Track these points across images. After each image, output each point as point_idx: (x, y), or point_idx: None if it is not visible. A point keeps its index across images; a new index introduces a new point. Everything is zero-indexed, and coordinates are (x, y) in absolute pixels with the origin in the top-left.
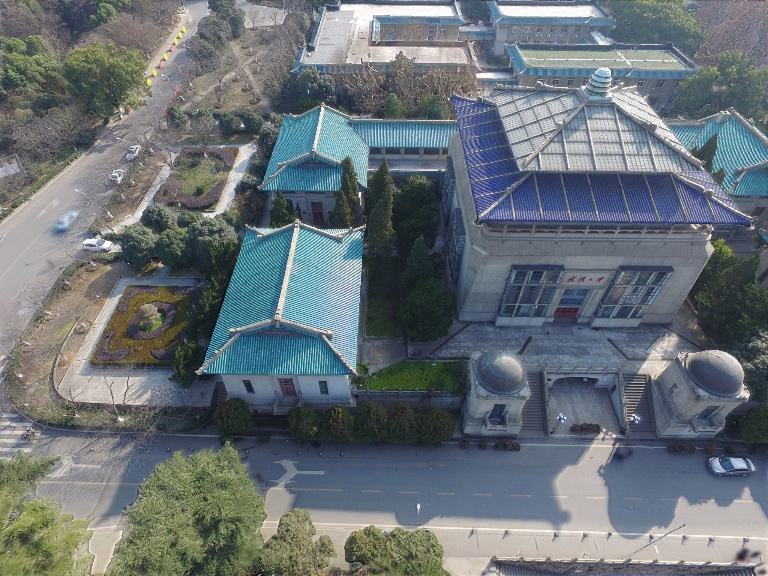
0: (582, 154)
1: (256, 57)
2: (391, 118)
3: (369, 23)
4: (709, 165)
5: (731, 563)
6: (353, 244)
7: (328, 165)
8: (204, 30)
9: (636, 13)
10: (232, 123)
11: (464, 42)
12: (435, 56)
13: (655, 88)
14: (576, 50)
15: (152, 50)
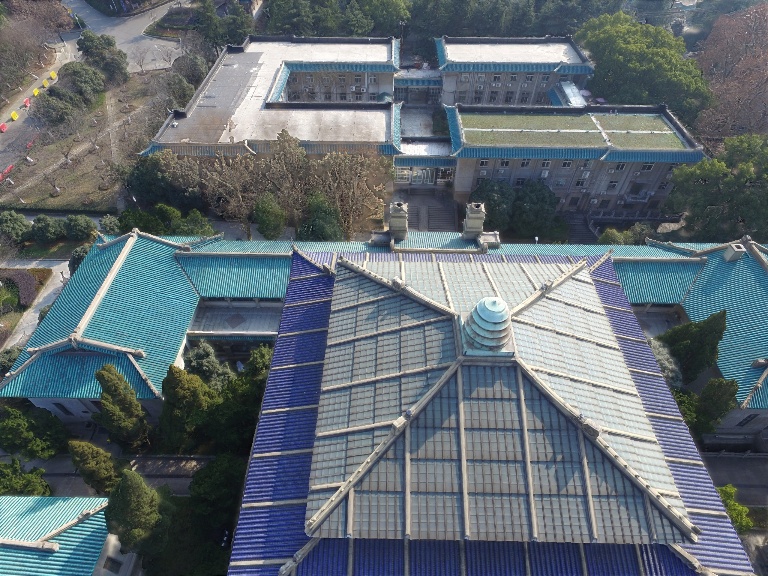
0: (441, 493)
1: (128, 117)
2: (262, 229)
3: (275, 72)
4: (712, 353)
5: None
6: (80, 548)
7: (104, 353)
8: (58, 83)
9: (619, 62)
10: (48, 231)
11: (387, 104)
12: (344, 126)
13: (641, 172)
14: (537, 114)
15: (3, 105)
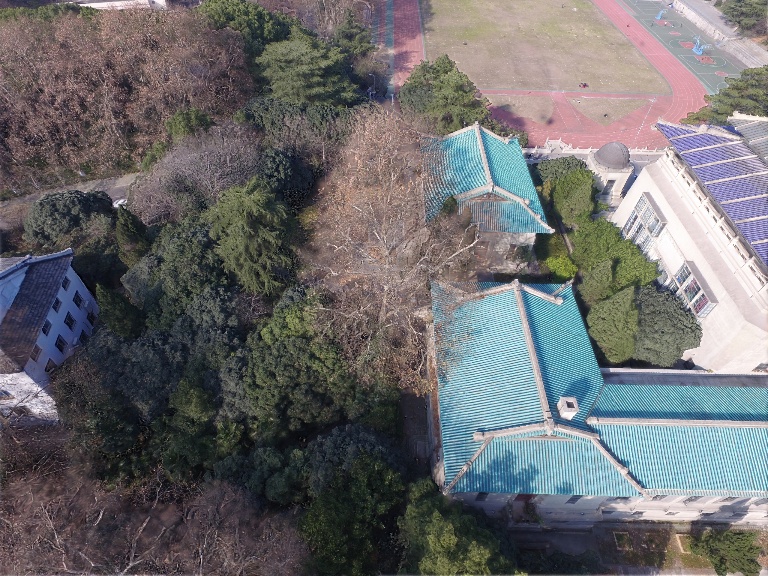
0: None
1: None
2: None
3: None
4: None
5: (578, 149)
6: None
7: None
8: None
9: None
10: None
11: None
12: None
13: None
14: None
15: None
